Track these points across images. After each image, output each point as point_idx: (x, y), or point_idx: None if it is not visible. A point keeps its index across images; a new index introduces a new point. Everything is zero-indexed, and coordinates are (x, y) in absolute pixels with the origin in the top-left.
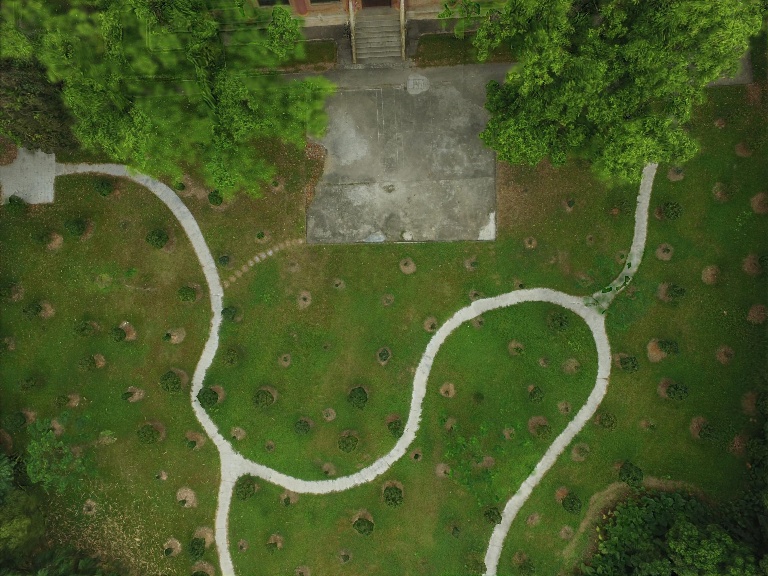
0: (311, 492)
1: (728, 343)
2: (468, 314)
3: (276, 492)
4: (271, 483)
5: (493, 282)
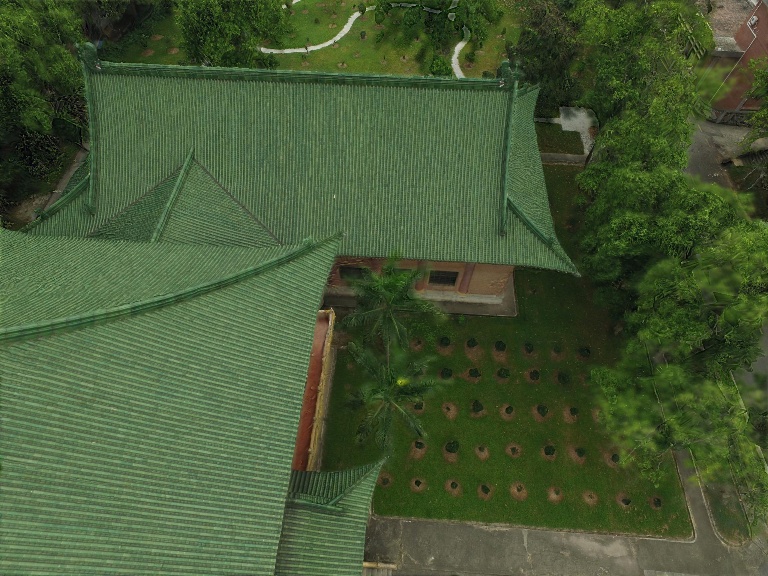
0: (410, 4)
1: (179, 30)
2: (313, 48)
3: (427, 5)
4: (430, 8)
5: (295, 57)
